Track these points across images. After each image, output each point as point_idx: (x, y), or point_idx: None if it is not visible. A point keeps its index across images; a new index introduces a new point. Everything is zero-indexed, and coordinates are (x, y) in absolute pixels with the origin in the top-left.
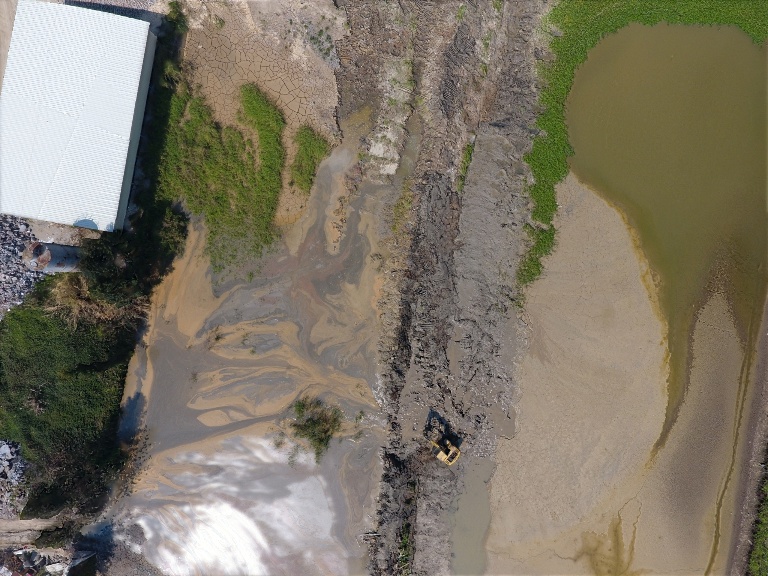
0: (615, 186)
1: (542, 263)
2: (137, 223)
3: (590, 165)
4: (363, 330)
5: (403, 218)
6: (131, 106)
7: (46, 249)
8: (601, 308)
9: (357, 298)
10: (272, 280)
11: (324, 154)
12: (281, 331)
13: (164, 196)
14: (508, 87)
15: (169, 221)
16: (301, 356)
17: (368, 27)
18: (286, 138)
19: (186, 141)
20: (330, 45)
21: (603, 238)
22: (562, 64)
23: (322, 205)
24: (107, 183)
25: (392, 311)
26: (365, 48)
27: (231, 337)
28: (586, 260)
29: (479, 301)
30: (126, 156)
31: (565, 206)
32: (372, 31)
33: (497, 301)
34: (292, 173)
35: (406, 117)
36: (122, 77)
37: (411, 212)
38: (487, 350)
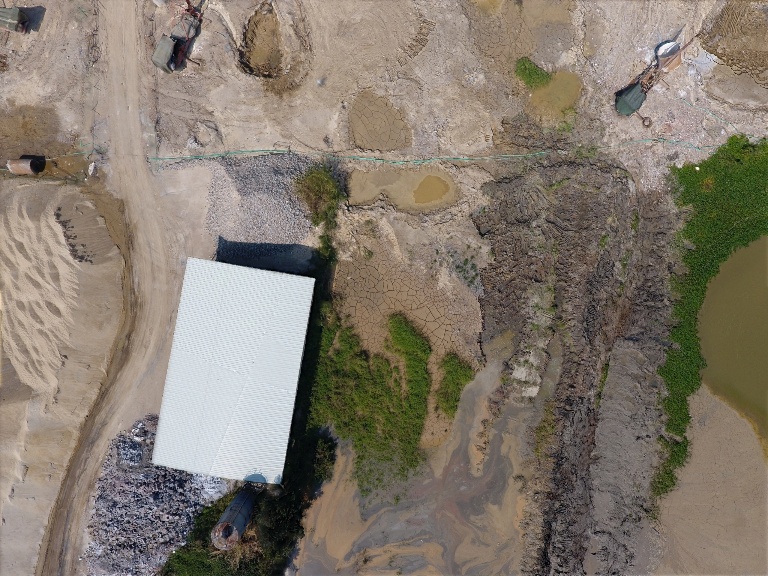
0: (746, 397)
1: (675, 475)
2: (290, 455)
3: (722, 376)
4: (506, 550)
5: (545, 441)
6: (297, 361)
7: (234, 529)
8: (733, 517)
9: (500, 519)
10: (417, 502)
11: (469, 380)
12: (426, 552)
13: (313, 423)
14: (642, 301)
15: (321, 451)
16: (446, 575)
17: (511, 254)
18: (431, 364)
19: (336, 372)
20: (475, 273)
21: (734, 448)
22: (695, 278)
23: (466, 428)
24: (275, 437)
25: (534, 531)
26: (508, 274)
27: (378, 559)
28: (718, 470)
29: (615, 514)
30: (292, 409)
31: (697, 417)
32: (514, 257)
33: (631, 512)
34: (438, 399)
35: (548, 341)
36: (289, 334)
37: (554, 437)
38: (622, 560)
